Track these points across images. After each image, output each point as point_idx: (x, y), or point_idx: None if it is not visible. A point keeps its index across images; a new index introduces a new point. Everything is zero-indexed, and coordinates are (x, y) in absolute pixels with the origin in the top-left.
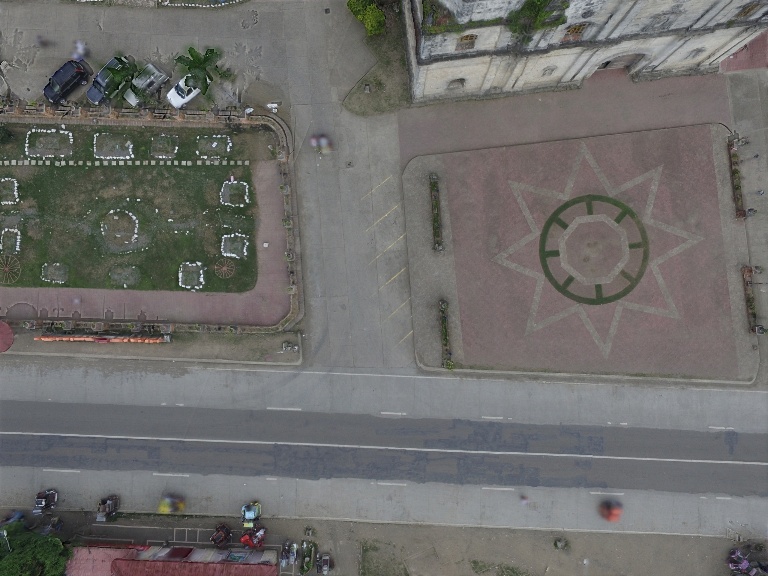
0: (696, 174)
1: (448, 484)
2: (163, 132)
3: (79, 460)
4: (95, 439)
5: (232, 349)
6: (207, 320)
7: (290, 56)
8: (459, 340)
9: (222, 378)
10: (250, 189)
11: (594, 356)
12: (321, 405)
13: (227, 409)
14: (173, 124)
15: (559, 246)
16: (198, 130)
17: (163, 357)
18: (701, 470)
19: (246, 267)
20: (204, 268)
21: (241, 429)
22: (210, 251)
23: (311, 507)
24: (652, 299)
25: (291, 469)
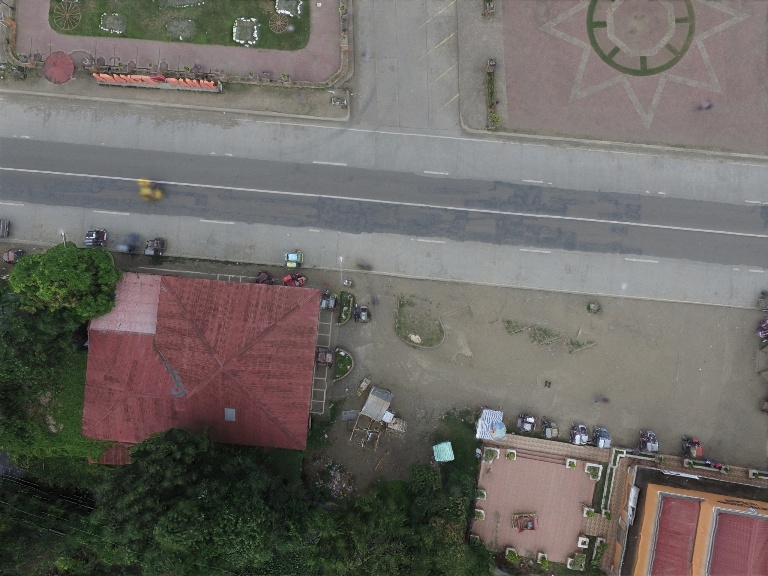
0: None
1: (486, 244)
2: None
3: (129, 203)
4: (145, 183)
5: (282, 102)
6: (258, 75)
7: None
8: (504, 104)
9: (271, 131)
10: None
11: (636, 126)
12: (366, 161)
13: (274, 161)
14: None
15: (606, 17)
16: None
17: (215, 107)
18: (736, 242)
19: (299, 26)
20: (258, 24)
21: (287, 181)
22: (265, 8)
23: (351, 260)
24: (696, 73)
25: (334, 222)
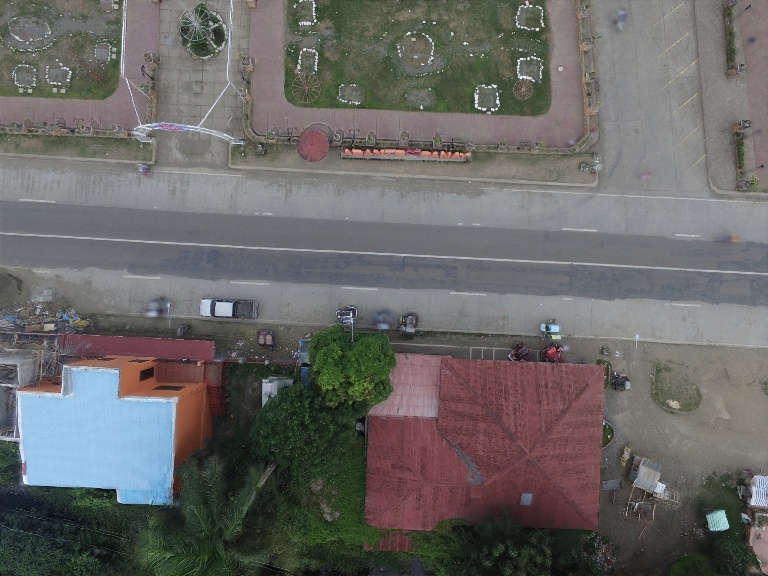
0: None
1: (741, 305)
2: None
3: (377, 278)
4: (393, 257)
5: (529, 170)
6: None
7: None
8: (752, 164)
9: (518, 199)
10: (544, 14)
11: None
12: (616, 226)
13: (523, 229)
14: None
15: None
16: None
17: (461, 177)
18: None
19: (540, 91)
20: (499, 91)
21: (537, 249)
22: (505, 74)
23: (606, 327)
24: None
25: (587, 289)
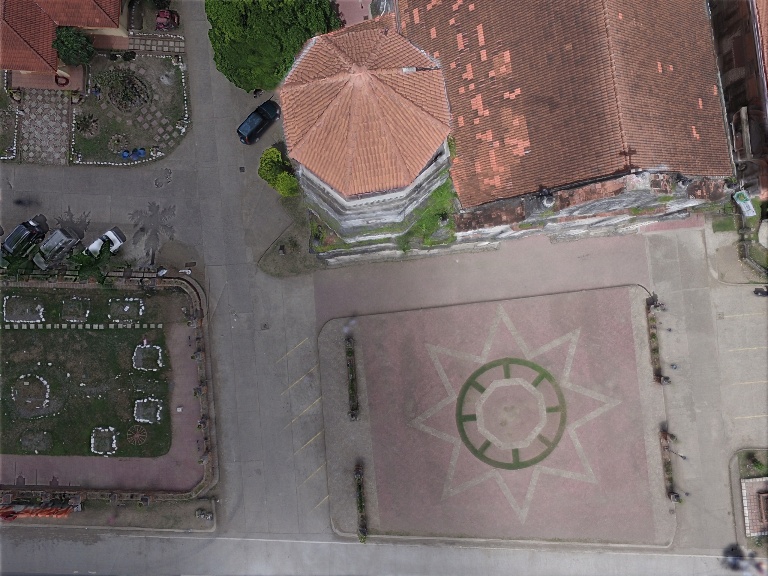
0: (614, 337)
1: None
2: (75, 294)
3: None
4: None
5: (145, 516)
6: (120, 485)
7: (204, 216)
8: (375, 505)
9: (135, 545)
10: (163, 352)
11: (510, 521)
12: (235, 572)
13: None
14: (85, 286)
15: (476, 410)
16: (110, 292)
17: (75, 525)
18: None
19: (160, 432)
20: (117, 433)
21: None
22: (123, 416)
23: None
24: (569, 463)
25: None
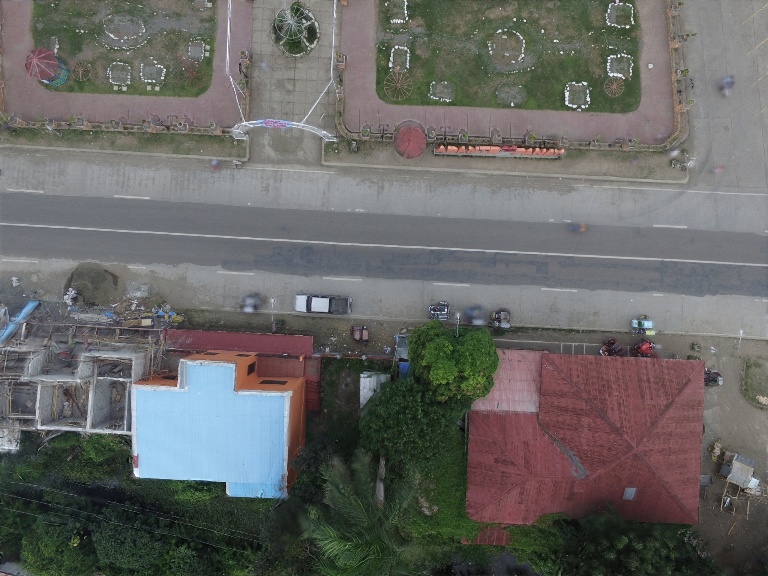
0: None
1: None
2: None
3: (468, 274)
4: (485, 254)
5: (620, 167)
6: None
7: None
8: None
9: (609, 196)
10: (634, 11)
11: None
12: (707, 223)
13: (614, 226)
14: None
15: None
16: None
17: (552, 173)
18: None
19: (630, 88)
20: (590, 88)
21: (628, 245)
22: (595, 71)
23: (697, 323)
24: None
25: (677, 285)
